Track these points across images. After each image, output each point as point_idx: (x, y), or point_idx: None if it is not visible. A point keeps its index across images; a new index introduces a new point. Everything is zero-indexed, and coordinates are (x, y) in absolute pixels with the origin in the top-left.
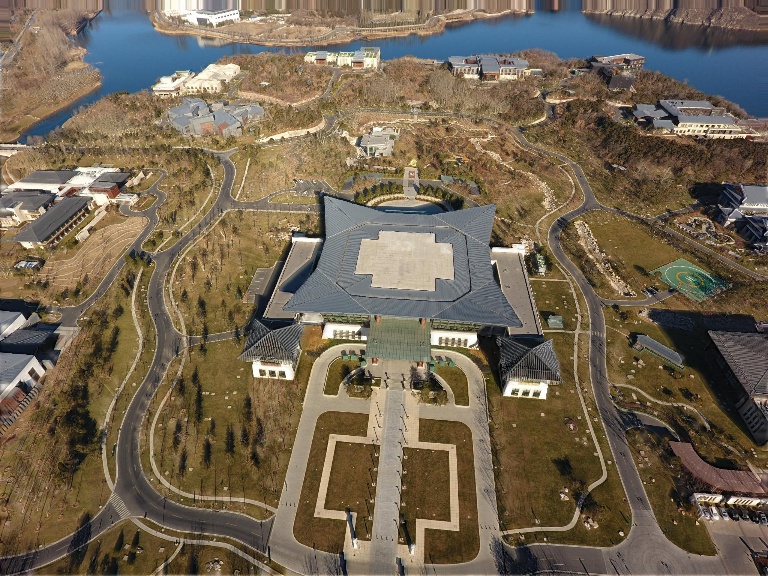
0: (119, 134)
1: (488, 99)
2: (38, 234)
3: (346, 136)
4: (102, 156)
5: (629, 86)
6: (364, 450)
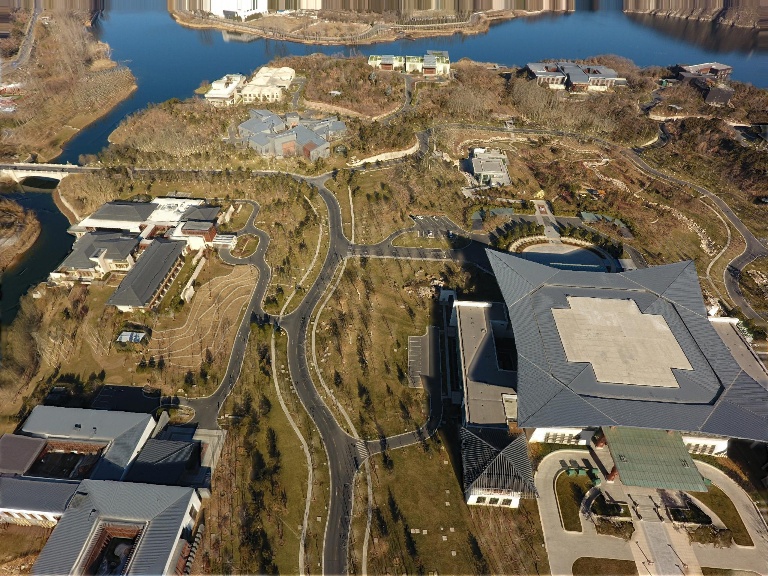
0: (185, 153)
1: (590, 115)
2: (140, 296)
3: (448, 159)
4: (175, 182)
5: (727, 100)
6: None
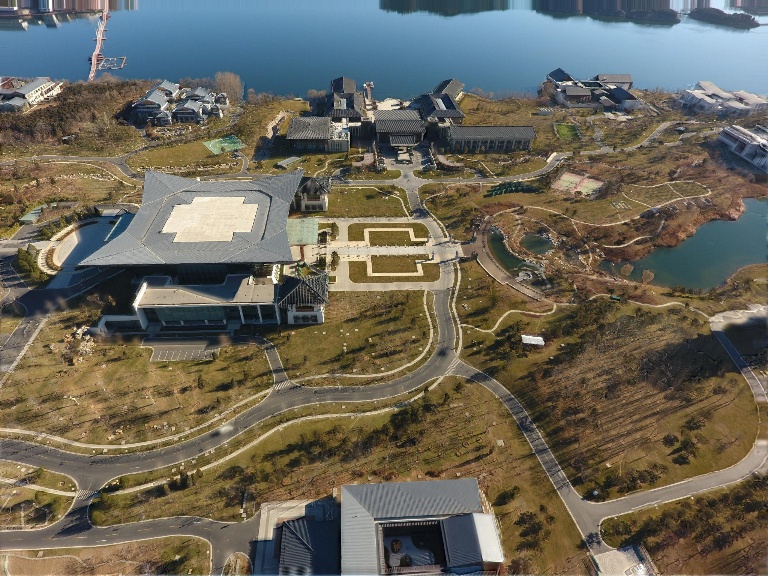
0: None
1: None
2: None
3: None
4: None
5: None
6: (376, 261)
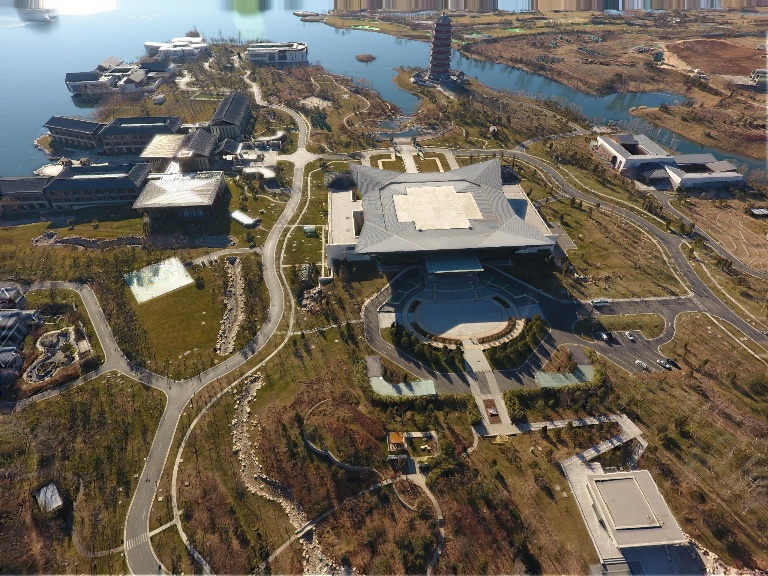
0: None
1: None
2: None
3: None
4: None
5: None
6: None
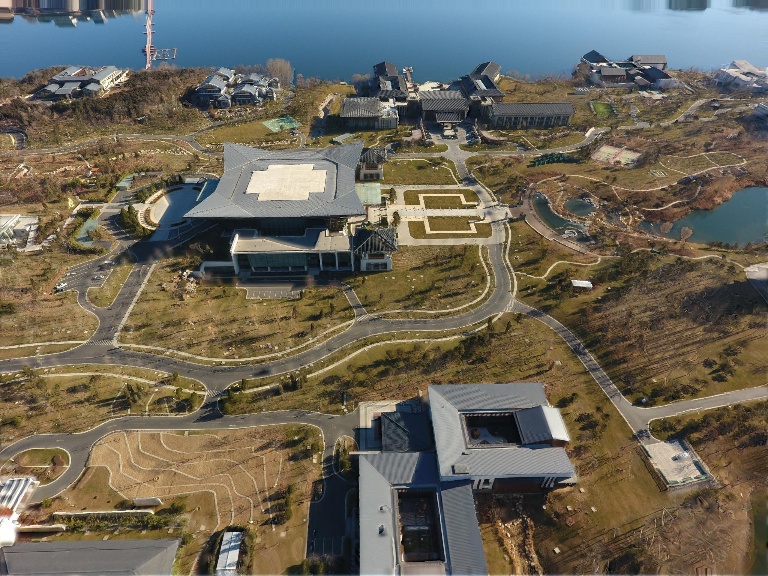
0: None
1: None
2: (158, 550)
3: None
4: None
5: None
6: (433, 221)
